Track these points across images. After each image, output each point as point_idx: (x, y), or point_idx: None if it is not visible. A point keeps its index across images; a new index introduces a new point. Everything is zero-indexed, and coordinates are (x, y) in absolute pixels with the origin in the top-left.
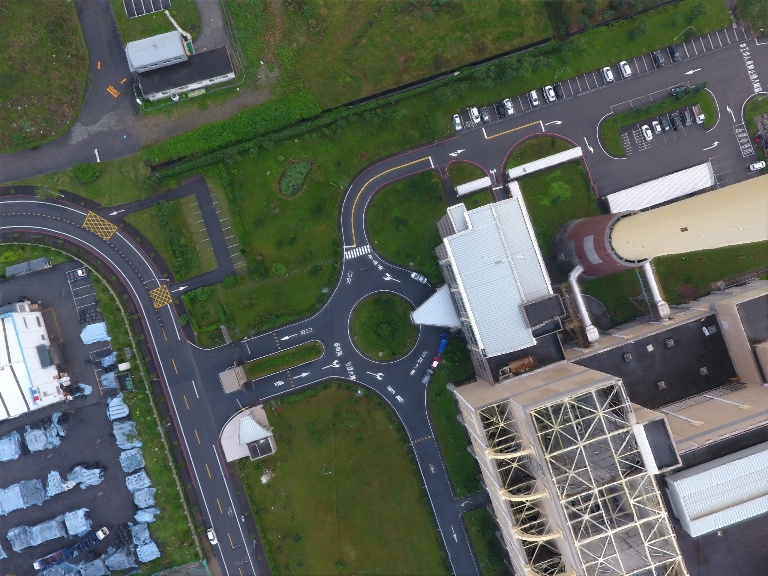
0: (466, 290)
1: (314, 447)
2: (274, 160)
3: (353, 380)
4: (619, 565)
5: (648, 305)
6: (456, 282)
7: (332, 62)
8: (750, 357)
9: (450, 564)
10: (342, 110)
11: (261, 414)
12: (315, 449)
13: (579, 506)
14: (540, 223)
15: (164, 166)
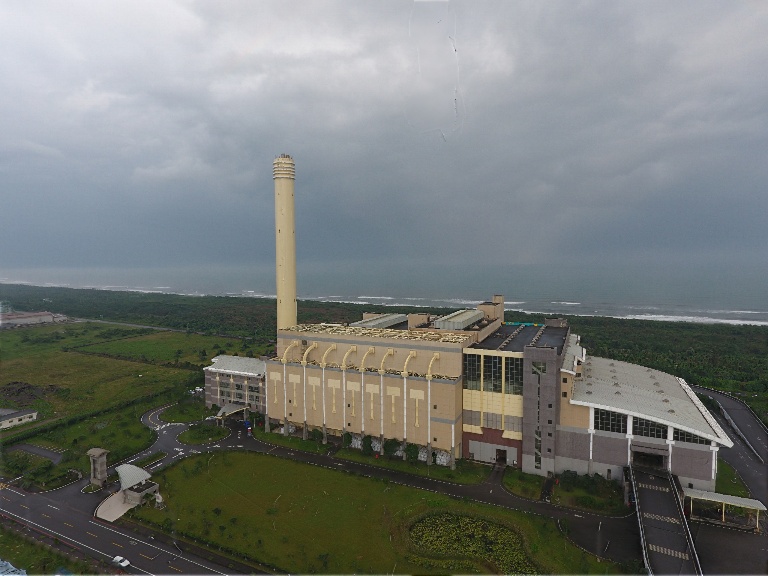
0: (233, 370)
1: None
2: (82, 424)
3: None
4: None
5: None
6: (228, 383)
7: (104, 402)
8: None
9: None
10: None
11: None
12: None
13: None
14: None
15: None
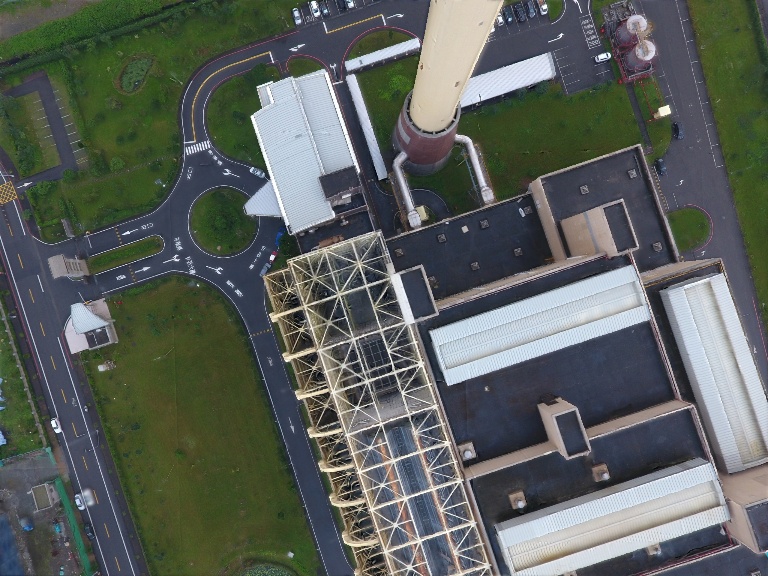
0: (271, 167)
1: (155, 340)
2: (114, 56)
3: (193, 274)
4: (376, 413)
5: (476, 193)
6: None
7: None
8: (555, 232)
9: (287, 455)
10: (183, 6)
11: (103, 307)
12: (156, 342)
13: (365, 371)
14: (380, 118)
15: (10, 64)
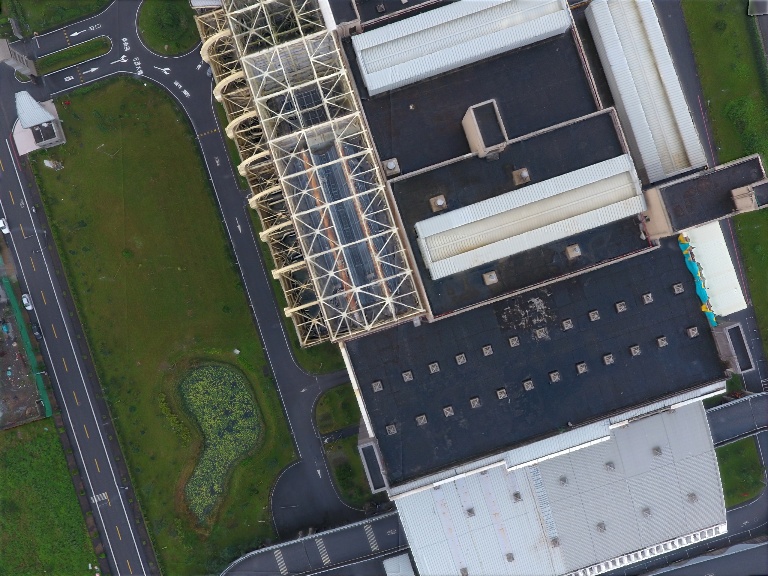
0: None
1: (102, 140)
2: None
3: (141, 75)
4: (298, 121)
5: None
6: None
7: None
8: None
9: (234, 254)
10: None
11: (51, 108)
12: (103, 142)
13: None
14: None
15: None
